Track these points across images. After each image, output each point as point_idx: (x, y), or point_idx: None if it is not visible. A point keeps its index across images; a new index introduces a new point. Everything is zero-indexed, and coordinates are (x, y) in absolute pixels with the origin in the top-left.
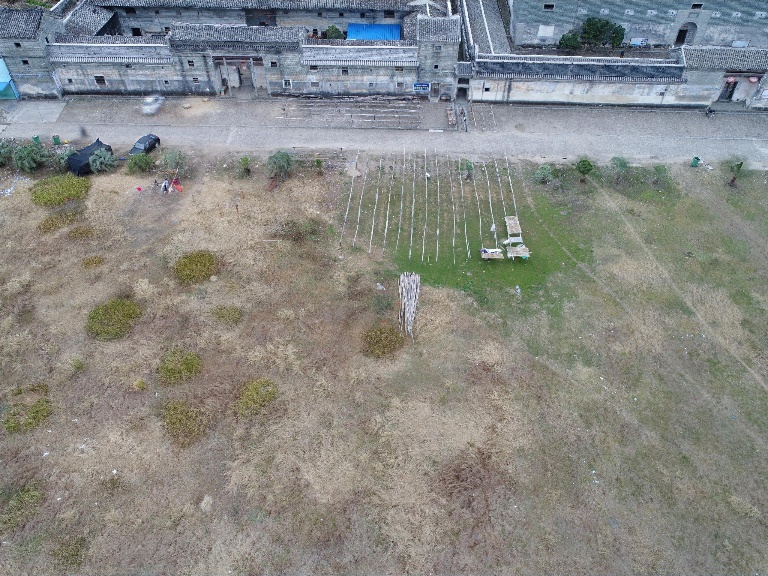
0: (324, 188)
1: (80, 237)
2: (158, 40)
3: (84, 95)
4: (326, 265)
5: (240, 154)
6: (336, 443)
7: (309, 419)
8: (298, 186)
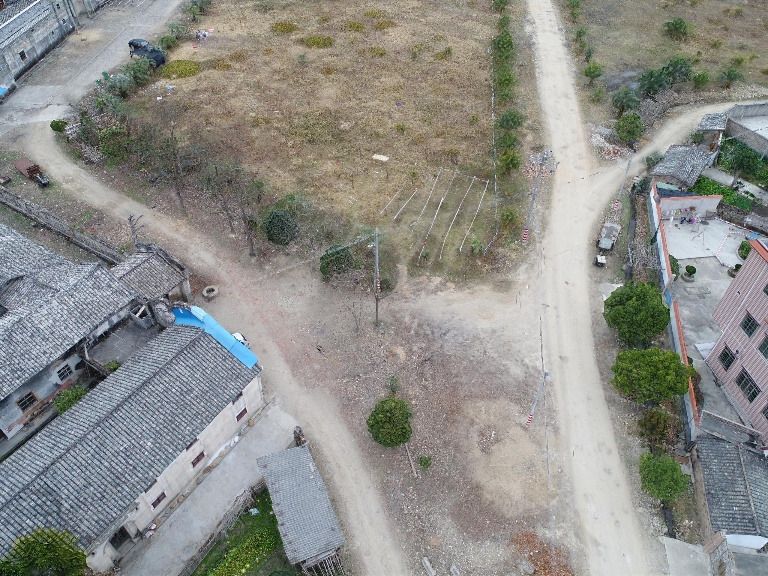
0: (224, 3)
1: (243, 57)
2: (21, 4)
3: (19, 79)
4: (293, 4)
5: (170, 22)
6: (398, 2)
7: (386, 7)
8: (219, 8)
